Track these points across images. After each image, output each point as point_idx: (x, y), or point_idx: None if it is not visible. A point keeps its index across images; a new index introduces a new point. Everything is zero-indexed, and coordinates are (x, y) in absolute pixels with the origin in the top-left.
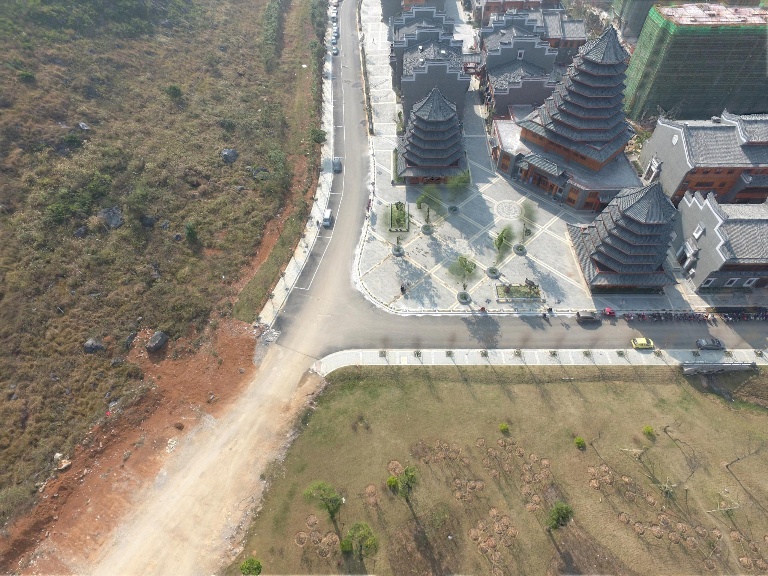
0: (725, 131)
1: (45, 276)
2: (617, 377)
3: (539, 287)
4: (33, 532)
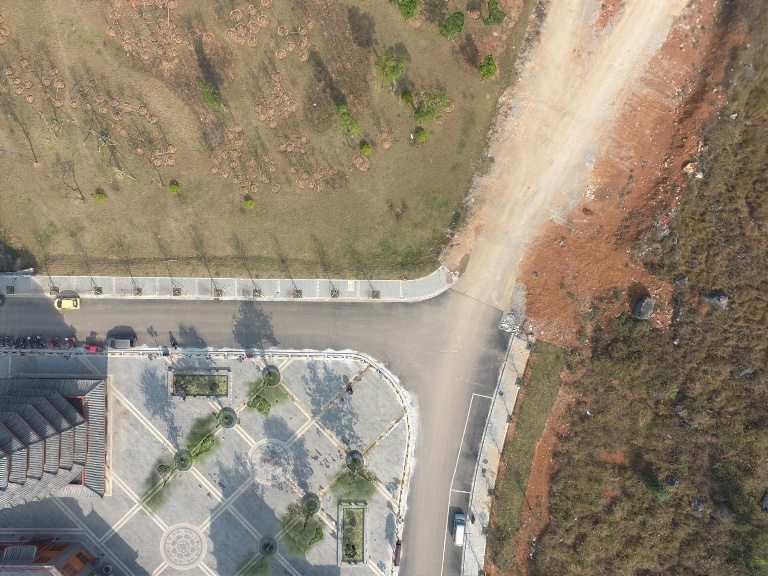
0: None
1: None
2: (113, 263)
3: (171, 392)
4: (690, 110)
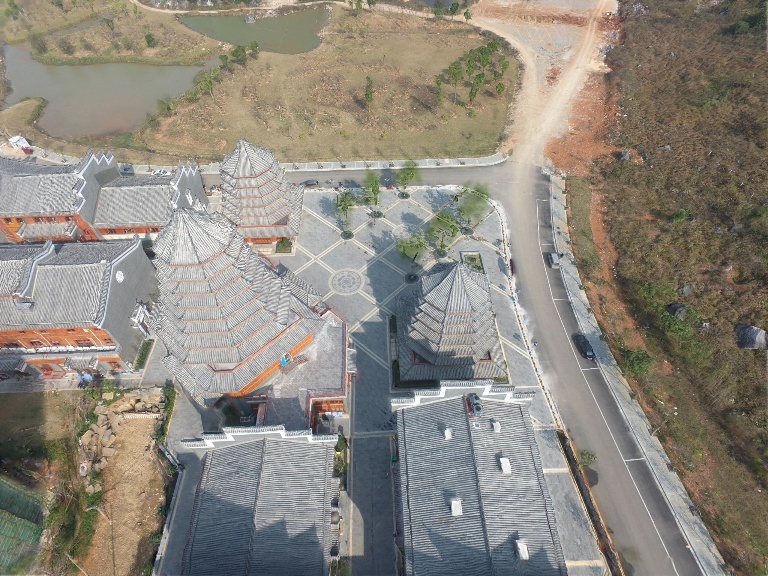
0: (56, 264)
1: (751, 163)
2: None
3: None
4: None
